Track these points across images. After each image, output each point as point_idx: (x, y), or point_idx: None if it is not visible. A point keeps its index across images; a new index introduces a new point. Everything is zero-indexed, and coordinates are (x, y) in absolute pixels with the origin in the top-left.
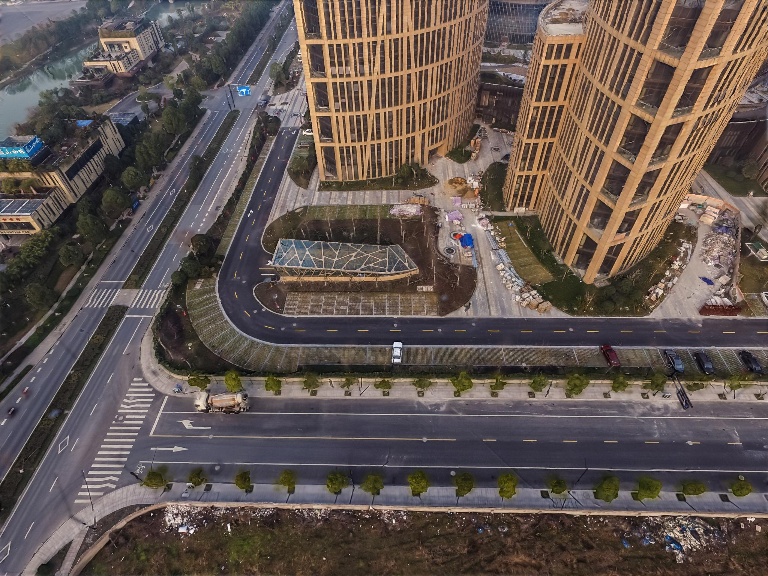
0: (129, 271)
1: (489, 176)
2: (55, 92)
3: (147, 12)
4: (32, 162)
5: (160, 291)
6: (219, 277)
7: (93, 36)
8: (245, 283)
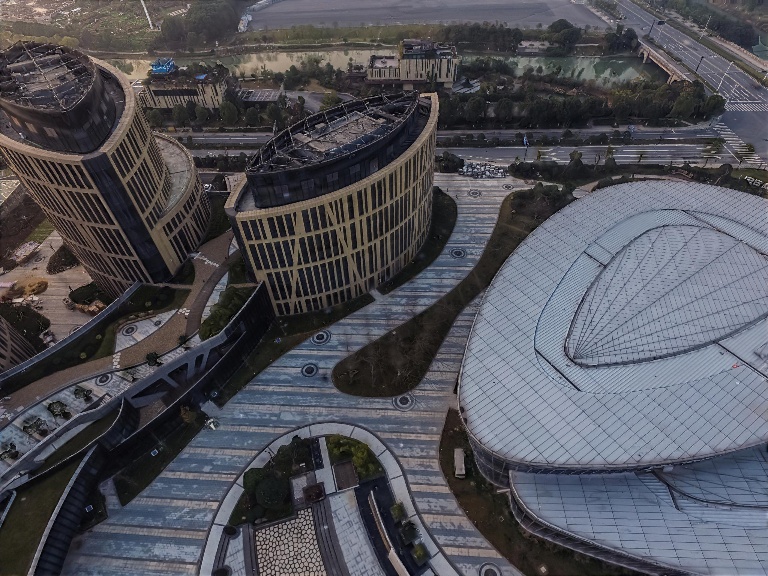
0: None
1: (24, 313)
2: (316, 62)
3: (600, 58)
4: (152, 75)
5: None
6: None
7: (499, 50)
8: None
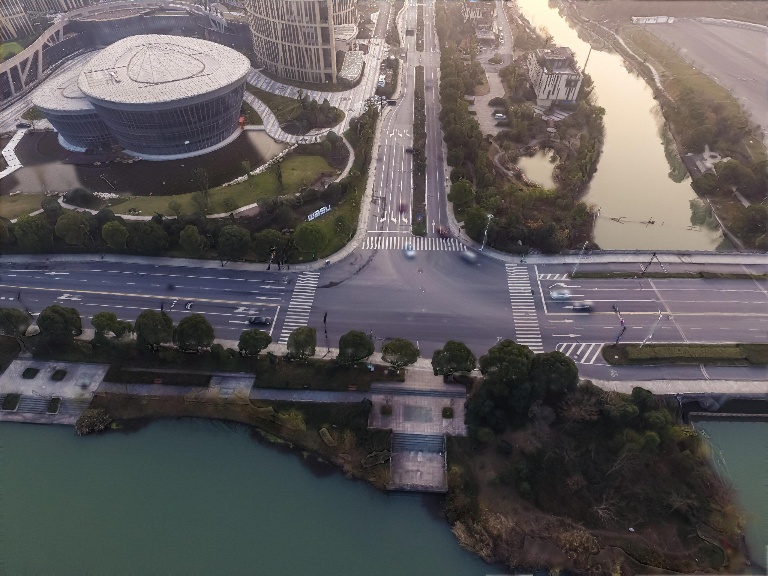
0: (425, 8)
1: None
2: None
3: None
4: None
5: (410, 5)
6: (391, 4)
7: None
8: (382, 3)
